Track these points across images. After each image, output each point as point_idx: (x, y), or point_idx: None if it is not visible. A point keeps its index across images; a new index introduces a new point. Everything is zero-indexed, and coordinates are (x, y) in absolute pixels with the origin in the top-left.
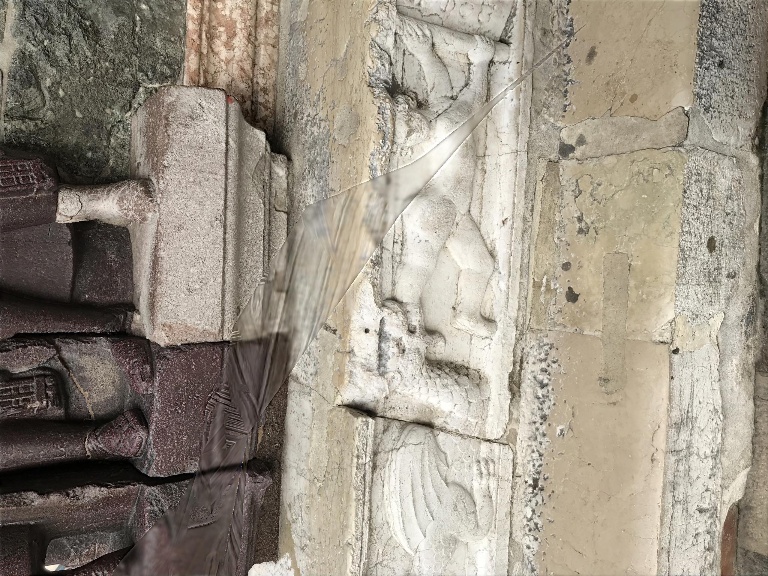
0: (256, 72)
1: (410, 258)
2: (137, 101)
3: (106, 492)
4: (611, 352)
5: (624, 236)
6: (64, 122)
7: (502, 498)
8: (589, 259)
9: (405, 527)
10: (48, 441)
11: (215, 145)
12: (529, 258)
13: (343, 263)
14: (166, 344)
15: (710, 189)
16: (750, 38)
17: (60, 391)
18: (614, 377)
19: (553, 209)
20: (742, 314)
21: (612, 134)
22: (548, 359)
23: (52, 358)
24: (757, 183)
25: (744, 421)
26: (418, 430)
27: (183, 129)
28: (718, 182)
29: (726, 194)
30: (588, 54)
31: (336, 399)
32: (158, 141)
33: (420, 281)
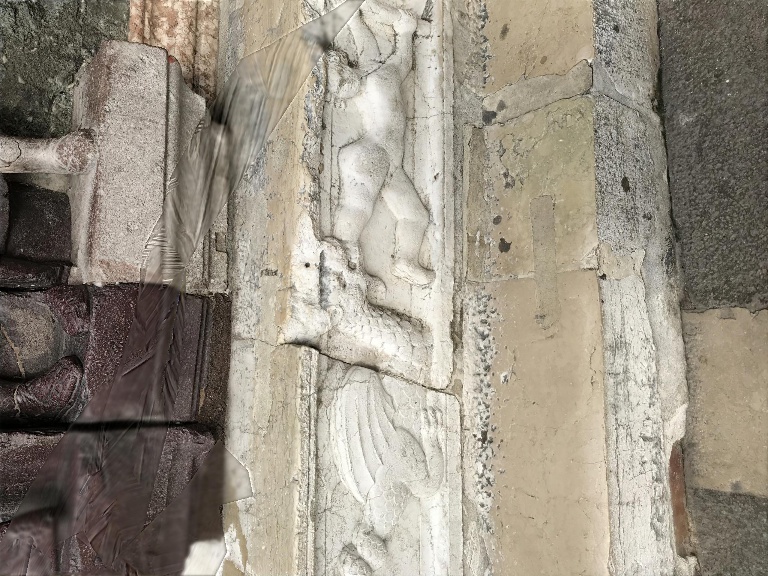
0: (197, 59)
1: (347, 200)
2: (80, 75)
3: (35, 440)
4: (544, 289)
5: (546, 180)
6: (6, 86)
7: (452, 450)
8: (517, 208)
9: (353, 469)
10: None
11: (156, 97)
12: (462, 214)
13: (276, 98)
14: (104, 283)
15: (619, 134)
16: (639, 12)
17: None
18: (549, 311)
19: (481, 170)
20: (662, 254)
21: (528, 94)
22: (487, 310)
23: None
24: (661, 138)
25: (676, 356)
26: (362, 369)
27: (125, 79)
28: (625, 130)
29: (634, 142)
30: (501, 31)
31: (279, 338)
32: (100, 90)
33: (358, 221)
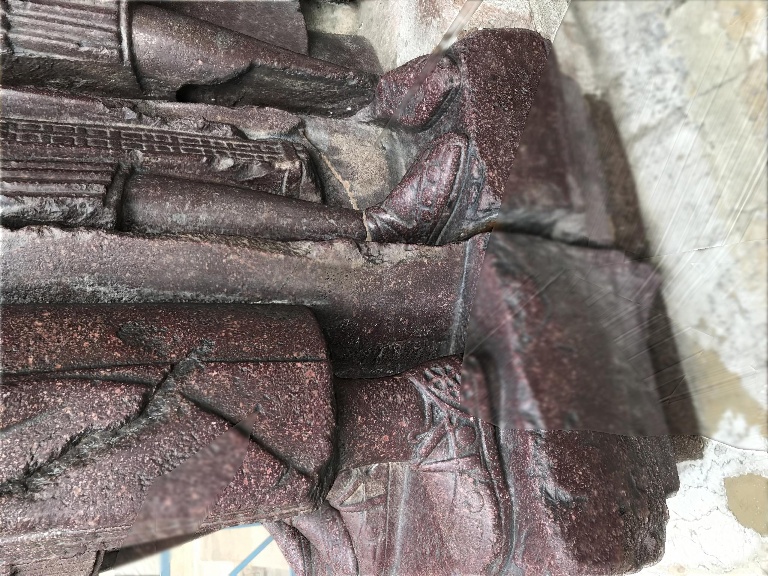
0: None
1: None
2: None
3: (416, 252)
4: None
5: None
6: None
7: None
8: None
9: None
10: (311, 208)
11: None
12: None
13: None
14: (461, 34)
15: None
16: None
17: (313, 168)
18: None
19: None
20: None
21: None
22: None
23: (296, 131)
24: None
25: None
26: None
27: None
28: None
29: None
30: None
31: None
32: None
33: None
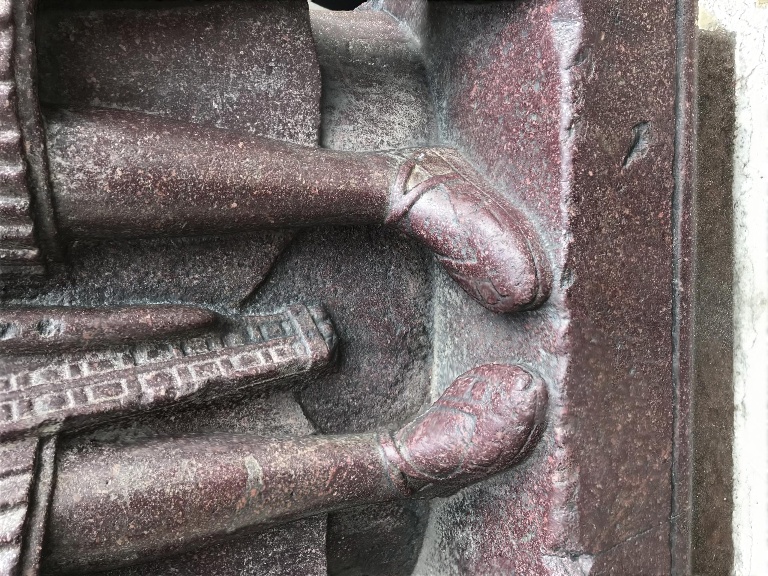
0: None
1: None
2: None
3: None
4: None
5: None
6: None
7: None
8: None
9: None
10: None
11: None
12: None
13: None
14: None
15: None
16: None
17: None
18: None
19: None
20: None
21: None
22: None
23: None
24: None
25: None
26: None
27: None
28: None
29: None
30: None
31: None
32: None
33: None
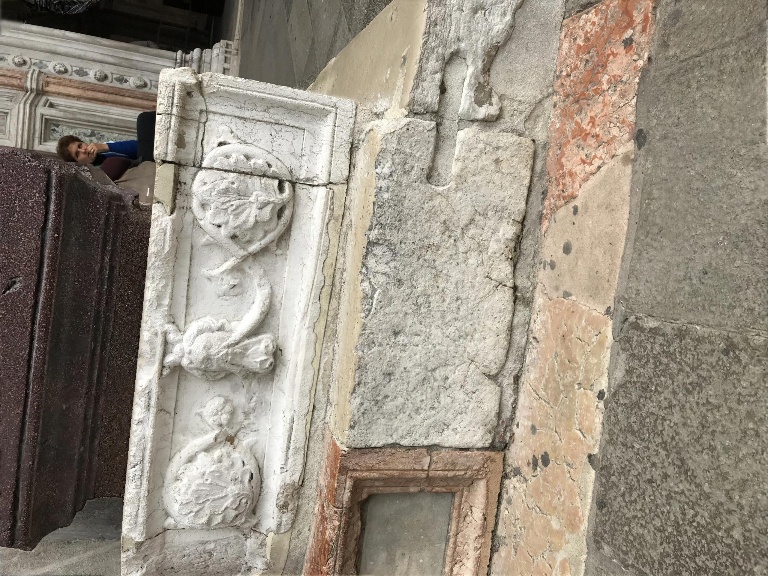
0: None
1: None
2: None
3: None
4: None
5: None
6: None
7: None
8: None
9: None
10: None
11: None
12: None
13: None
14: None
15: None
16: None
17: None
18: None
19: None
20: None
21: None
22: None
23: None
24: None
25: None
26: None
27: None
28: None
29: None
30: None
31: None
32: None
33: None
